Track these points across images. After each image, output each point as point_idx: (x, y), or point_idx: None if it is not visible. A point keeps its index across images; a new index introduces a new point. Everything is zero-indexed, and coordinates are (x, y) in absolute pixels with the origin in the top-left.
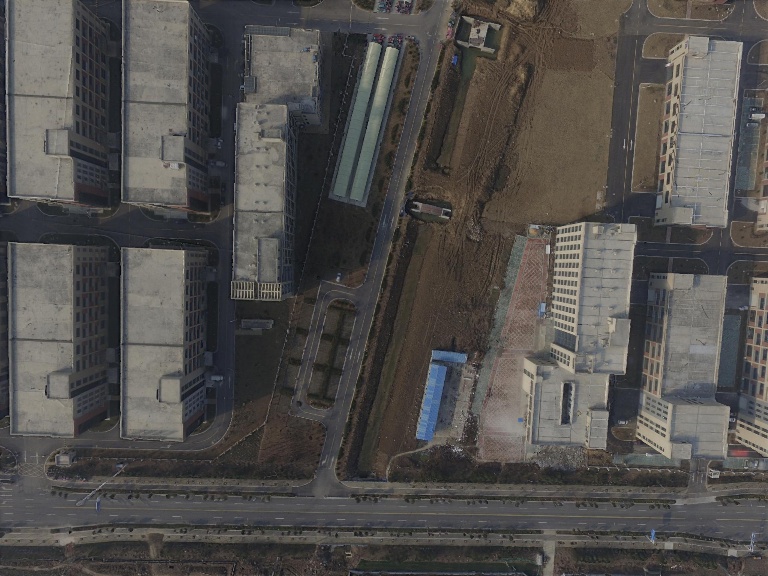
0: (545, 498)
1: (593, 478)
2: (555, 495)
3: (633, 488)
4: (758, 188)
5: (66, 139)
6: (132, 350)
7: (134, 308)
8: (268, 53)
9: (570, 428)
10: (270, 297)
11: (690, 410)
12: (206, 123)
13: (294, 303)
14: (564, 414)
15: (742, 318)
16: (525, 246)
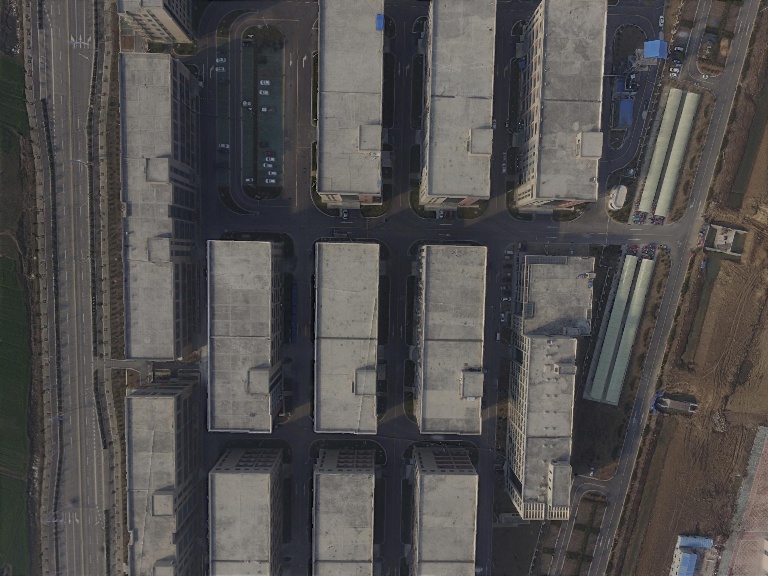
0: None
1: None
2: None
3: None
4: None
5: (374, 380)
6: (425, 567)
7: (428, 528)
8: (546, 280)
9: None
10: (558, 516)
11: None
12: None
13: None
14: None
15: None
16: (767, 436)
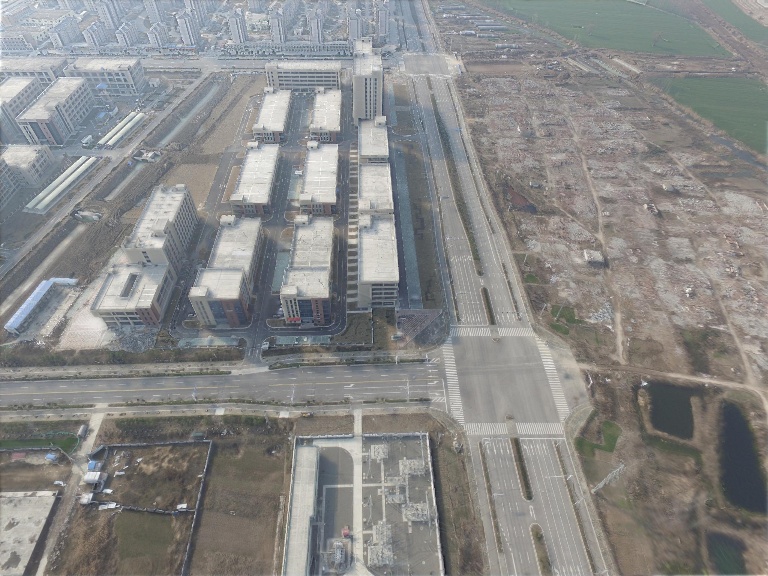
0: (107, 375)
1: None
2: None
3: (192, 363)
4: None
5: None
6: None
7: None
8: (13, 152)
9: (128, 300)
10: None
11: (215, 273)
12: None
13: None
14: None
15: None
16: None
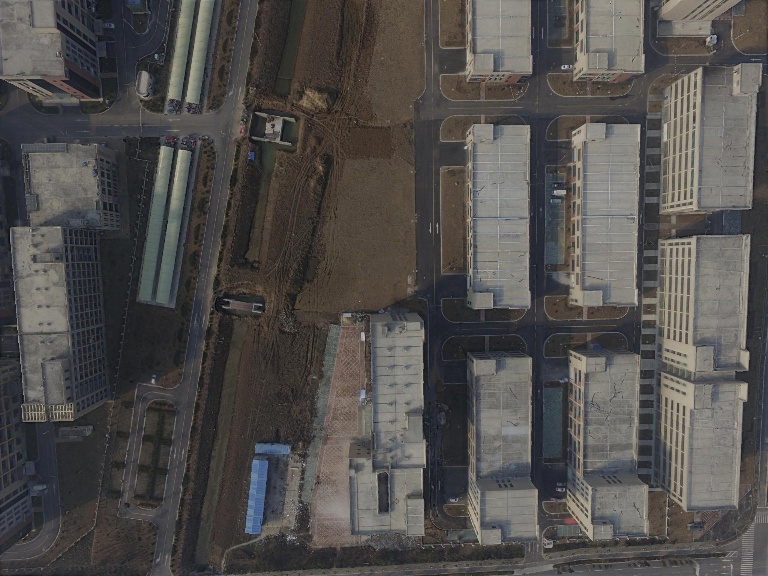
0: None
1: (428, 556)
2: (393, 575)
3: (470, 562)
4: (568, 262)
5: None
6: None
7: None
8: (47, 170)
9: (389, 516)
10: (63, 417)
11: (499, 495)
12: (2, 238)
13: (110, 408)
14: (386, 501)
15: (563, 390)
16: (340, 335)
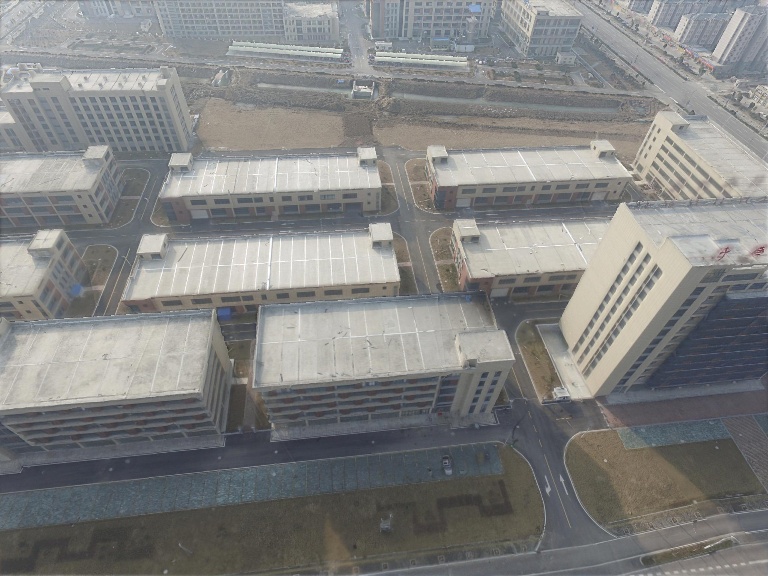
0: None
1: None
2: None
3: None
4: None
5: None
6: None
7: None
8: (321, 7)
9: None
10: None
11: None
12: None
13: None
14: None
15: None
16: None
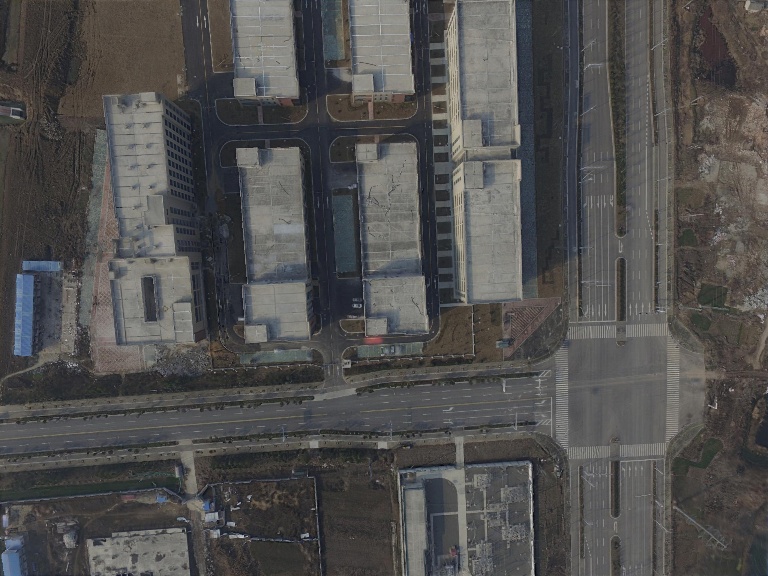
0: (174, 407)
1: None
2: (184, 403)
3: (266, 388)
4: (348, 57)
5: None
6: None
7: None
8: None
9: (159, 325)
10: None
11: (265, 291)
12: None
13: None
14: None
15: (353, 197)
16: None
